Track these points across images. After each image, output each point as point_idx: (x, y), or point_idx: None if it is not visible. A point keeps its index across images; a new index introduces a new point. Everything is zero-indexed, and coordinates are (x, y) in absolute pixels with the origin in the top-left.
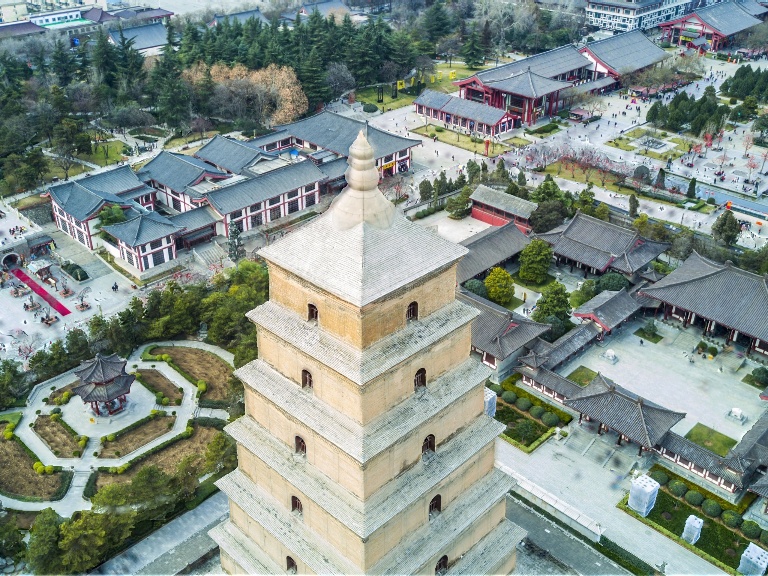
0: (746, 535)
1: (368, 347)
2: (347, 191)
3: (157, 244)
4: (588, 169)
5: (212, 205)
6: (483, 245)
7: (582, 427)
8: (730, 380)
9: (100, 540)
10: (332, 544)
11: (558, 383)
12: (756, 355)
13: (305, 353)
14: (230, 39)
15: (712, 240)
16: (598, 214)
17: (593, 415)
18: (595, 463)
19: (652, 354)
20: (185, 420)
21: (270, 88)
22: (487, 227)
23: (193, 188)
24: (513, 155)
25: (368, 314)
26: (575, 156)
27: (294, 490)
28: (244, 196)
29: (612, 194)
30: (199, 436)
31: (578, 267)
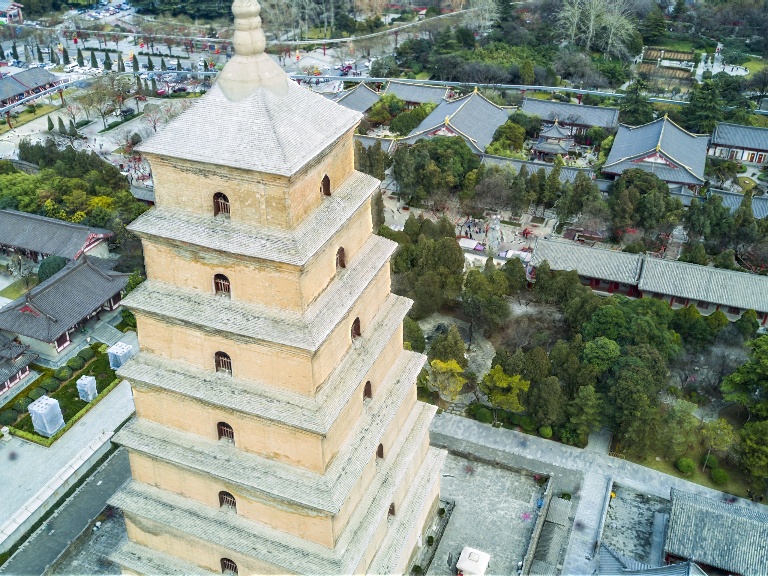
0: (81, 368)
1: None
2: (258, 59)
3: None
4: None
5: None
6: None
7: None
8: None
9: None
10: None
11: None
12: None
13: None
14: None
15: None
16: None
17: None
18: None
19: None
20: None
21: None
22: None
23: None
24: None
25: None
26: None
27: None
28: None
29: None
30: None
31: None
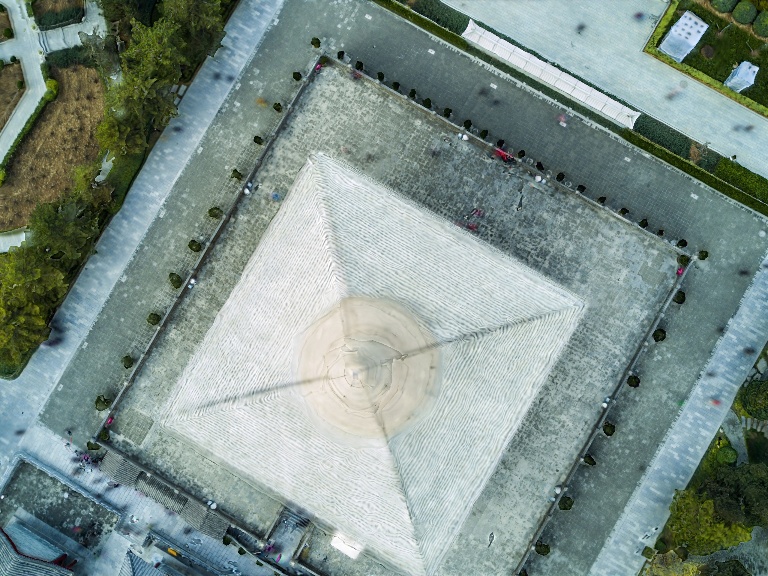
0: None
1: None
2: None
3: None
4: None
5: None
6: None
7: None
8: None
9: (39, 320)
10: None
11: None
12: None
13: None
14: None
15: None
16: None
17: None
18: None
19: None
20: (35, 64)
21: None
22: None
23: None
24: None
25: None
26: None
27: None
28: None
29: None
30: (68, 88)
31: None
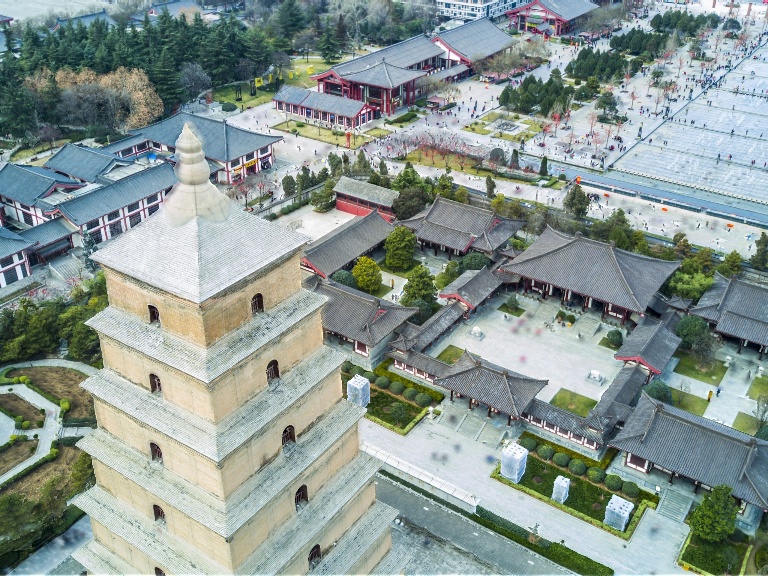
0: (610, 488)
1: (213, 344)
2: (178, 187)
3: (8, 262)
4: (447, 155)
5: (65, 216)
6: (348, 236)
7: (454, 404)
8: (588, 345)
9: None
10: (198, 548)
11: (428, 364)
12: (610, 319)
13: (149, 356)
14: (74, 43)
15: (564, 214)
16: (458, 197)
17: (463, 391)
18: (468, 437)
19: (516, 327)
20: (48, 442)
21: (121, 92)
22: (352, 218)
23: (44, 200)
24: (375, 146)
25: (209, 310)
26: (434, 143)
27: (154, 499)
28: (100, 205)
29: (471, 177)
30: (65, 457)
31: (442, 250)
